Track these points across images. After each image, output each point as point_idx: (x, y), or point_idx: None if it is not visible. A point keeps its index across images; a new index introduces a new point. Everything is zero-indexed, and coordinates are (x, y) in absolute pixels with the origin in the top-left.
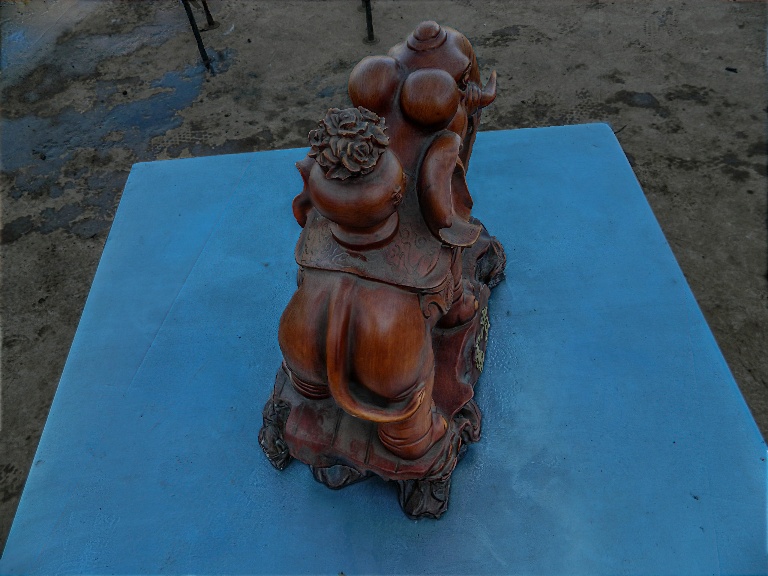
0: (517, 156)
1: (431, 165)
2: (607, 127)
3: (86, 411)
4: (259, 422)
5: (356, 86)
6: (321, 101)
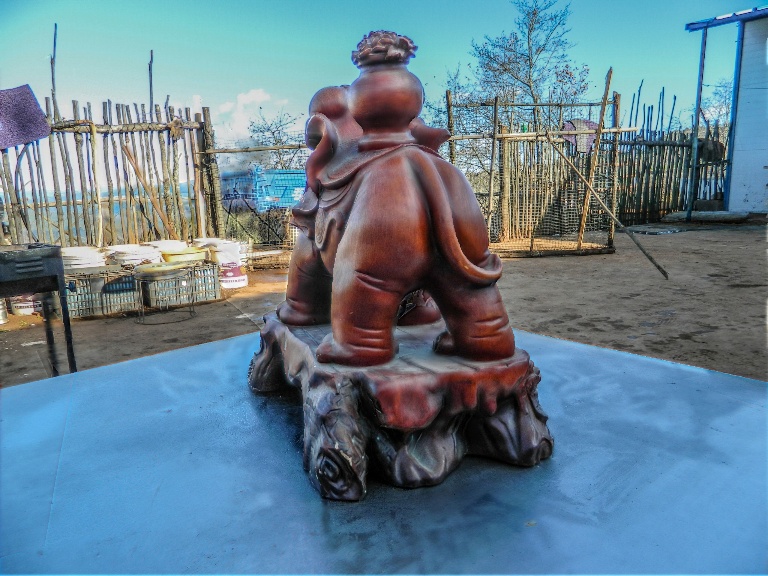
0: None
1: None
2: None
3: None
4: (291, 486)
5: (326, 93)
6: None
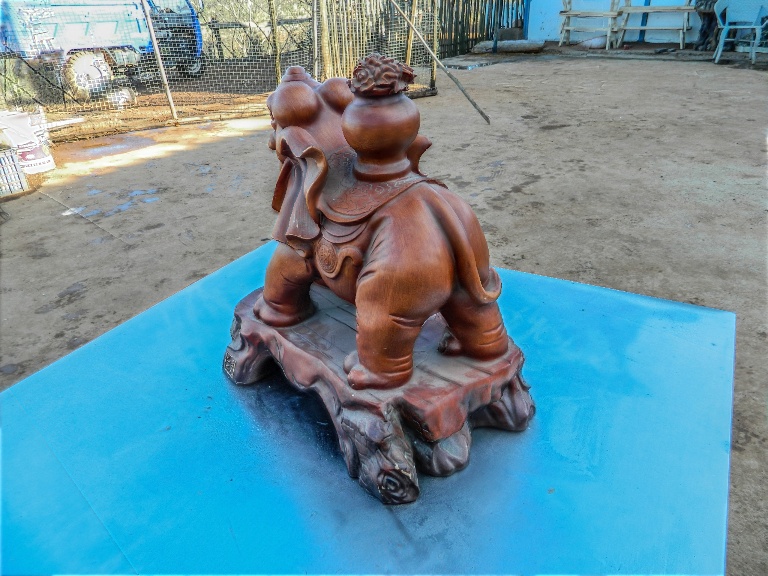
0: (265, 265)
1: None
2: None
3: None
4: (350, 498)
5: (296, 98)
6: None
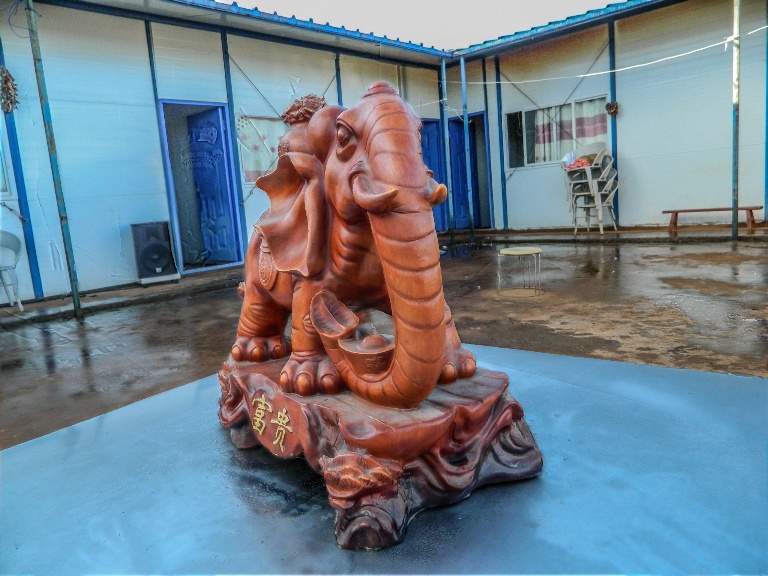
0: None
1: None
2: None
3: None
4: None
5: None
6: None
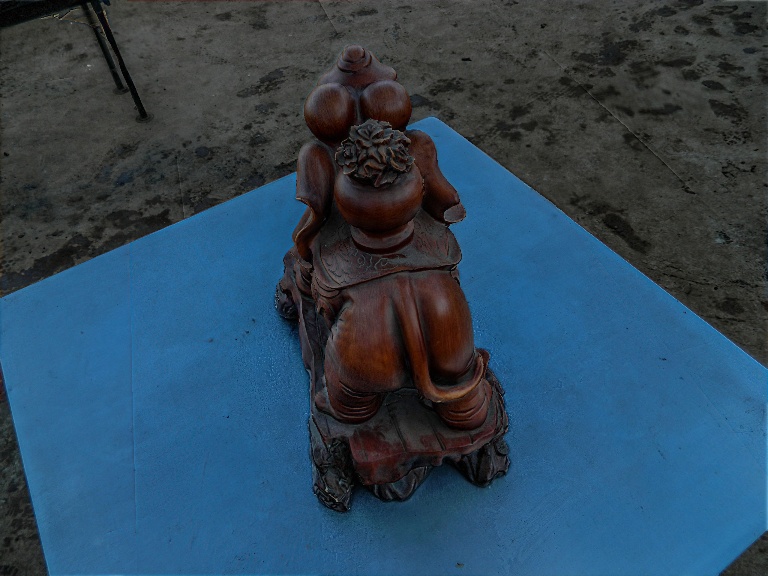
0: None
1: (416, 160)
2: (435, 119)
3: (100, 570)
4: (299, 481)
5: (321, 114)
6: (123, 189)
